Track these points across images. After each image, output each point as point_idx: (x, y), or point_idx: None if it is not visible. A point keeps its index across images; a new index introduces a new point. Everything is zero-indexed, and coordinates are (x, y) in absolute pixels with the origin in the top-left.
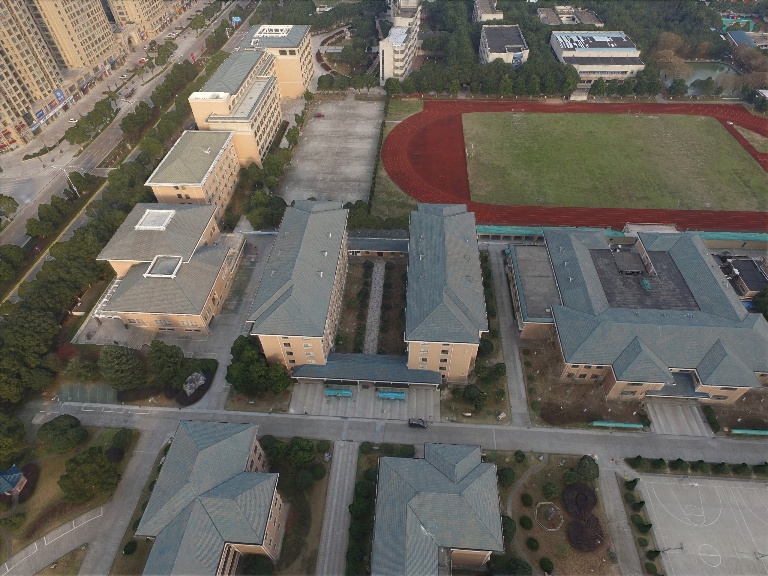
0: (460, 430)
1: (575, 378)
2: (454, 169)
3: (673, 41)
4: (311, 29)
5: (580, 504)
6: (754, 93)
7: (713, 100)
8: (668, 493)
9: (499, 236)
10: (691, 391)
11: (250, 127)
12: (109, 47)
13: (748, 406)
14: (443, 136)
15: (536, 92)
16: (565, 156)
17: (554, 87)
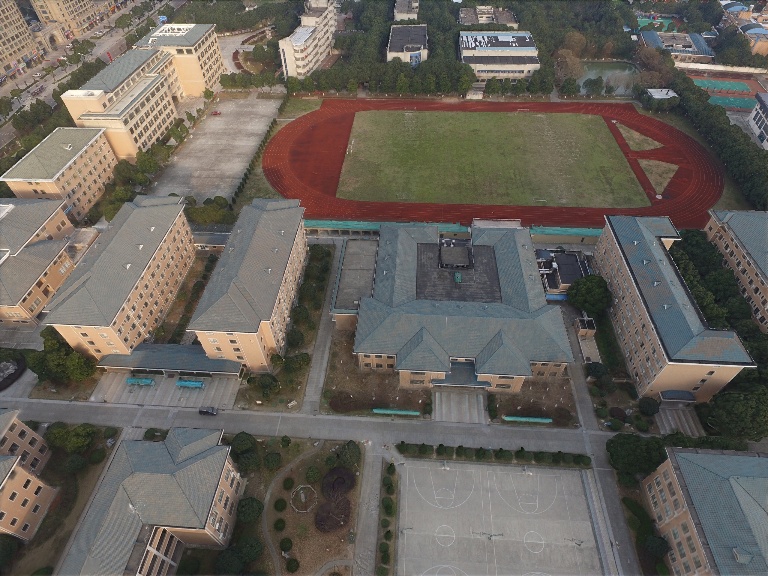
0: (248, 417)
1: (372, 368)
2: (329, 166)
3: (577, 41)
4: (234, 28)
5: (336, 487)
6: (643, 92)
7: (606, 99)
8: (426, 477)
9: (348, 231)
10: (474, 380)
11: (123, 124)
12: (25, 45)
13: (533, 395)
14: (330, 134)
15: (432, 91)
16: (442, 153)
17: (449, 86)
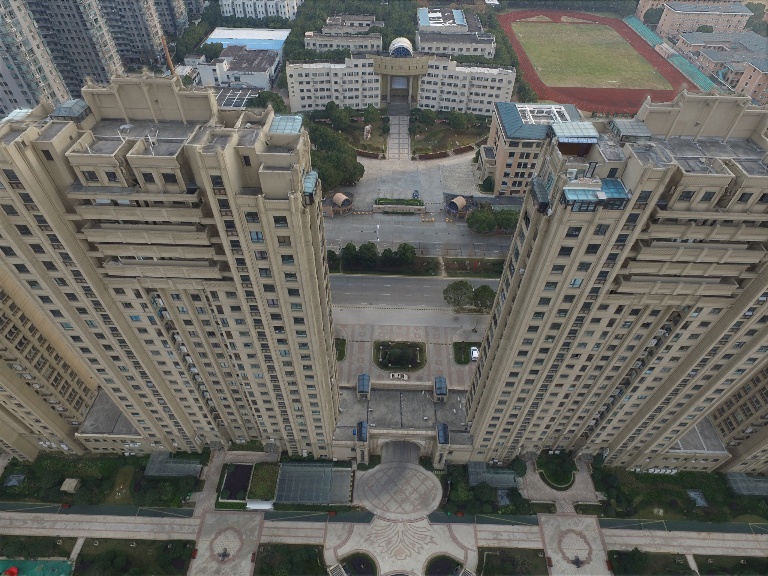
0: None
1: None
2: (640, 93)
3: None
4: None
5: None
6: None
7: None
8: None
9: None
10: None
11: None
12: None
13: None
14: (593, 94)
15: None
16: (593, 61)
17: None
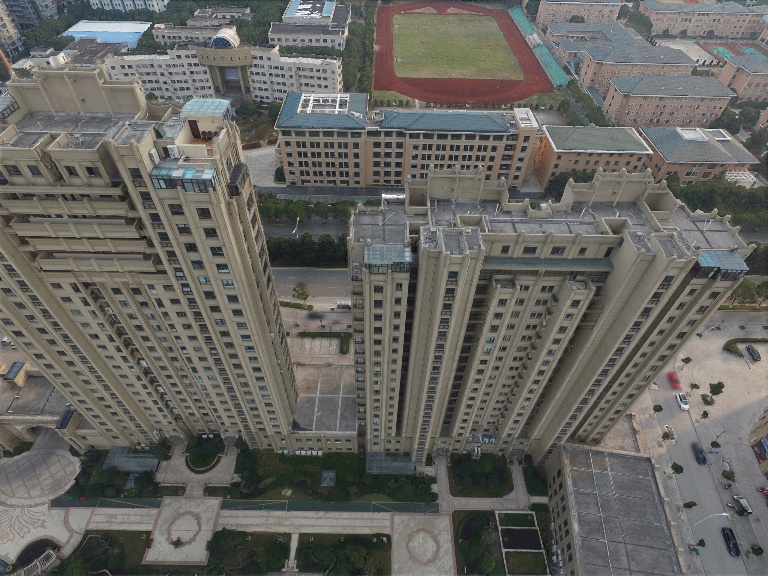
0: None
1: None
2: (487, 83)
3: None
4: None
5: None
6: None
7: None
8: None
9: None
10: None
11: None
12: None
13: None
14: (439, 85)
15: None
16: (457, 52)
17: None
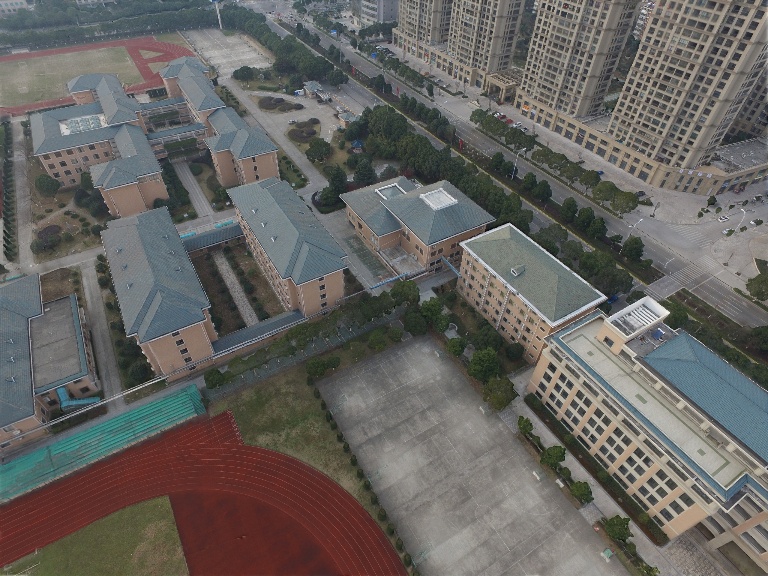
0: None
1: None
2: None
3: None
4: None
5: None
6: None
7: None
8: None
9: None
10: None
11: (549, 347)
12: None
13: None
14: None
15: None
16: None
17: None
